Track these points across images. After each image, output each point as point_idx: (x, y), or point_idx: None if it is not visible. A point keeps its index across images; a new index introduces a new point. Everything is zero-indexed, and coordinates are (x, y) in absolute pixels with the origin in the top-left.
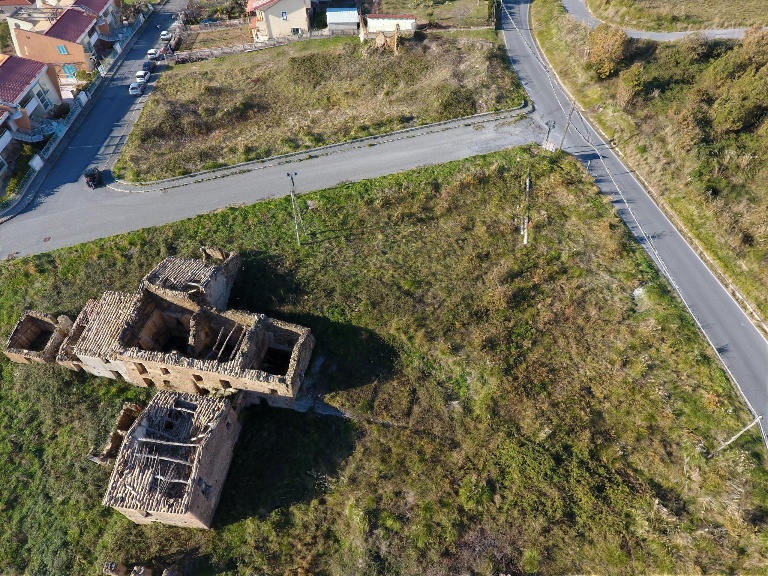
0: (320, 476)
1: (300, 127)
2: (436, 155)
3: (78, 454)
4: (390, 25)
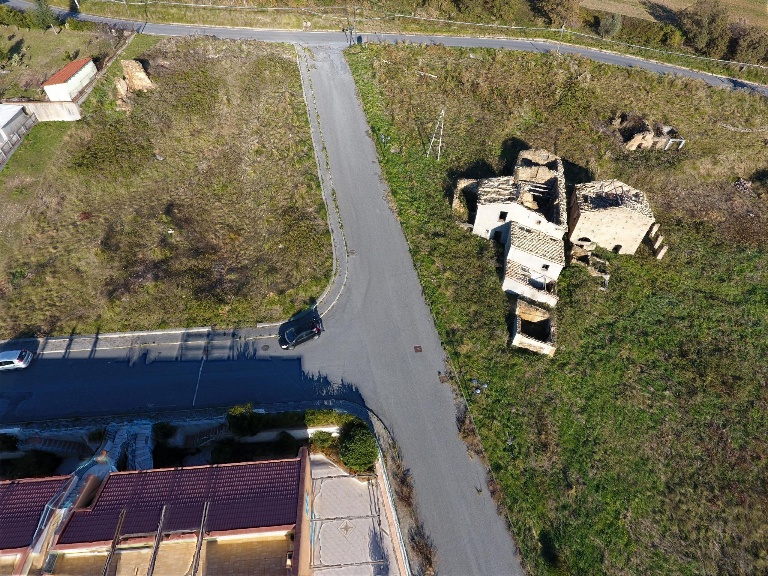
0: (591, 170)
1: (277, 151)
2: (344, 89)
3: (606, 295)
4: (84, 78)
